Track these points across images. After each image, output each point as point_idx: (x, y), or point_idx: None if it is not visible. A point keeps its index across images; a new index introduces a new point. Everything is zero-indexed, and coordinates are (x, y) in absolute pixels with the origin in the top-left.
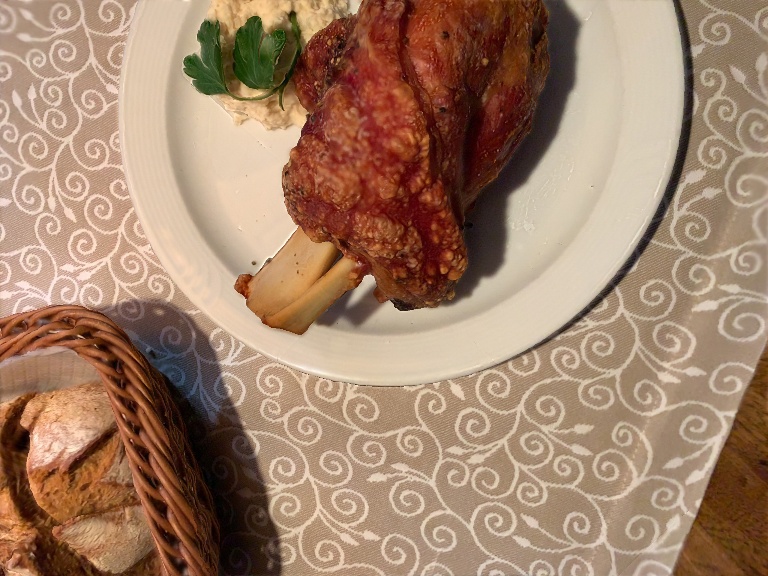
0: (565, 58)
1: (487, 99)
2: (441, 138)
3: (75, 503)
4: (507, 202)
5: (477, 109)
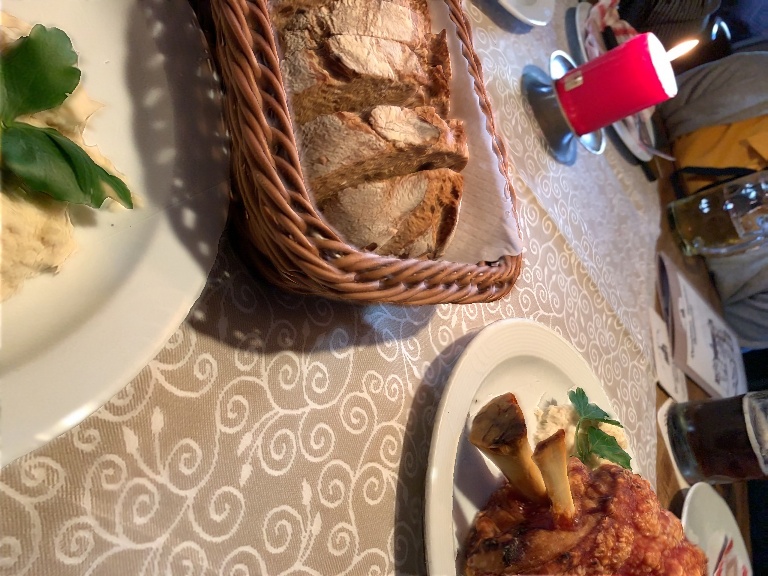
0: None
1: None
2: None
3: (428, 196)
4: None
5: None
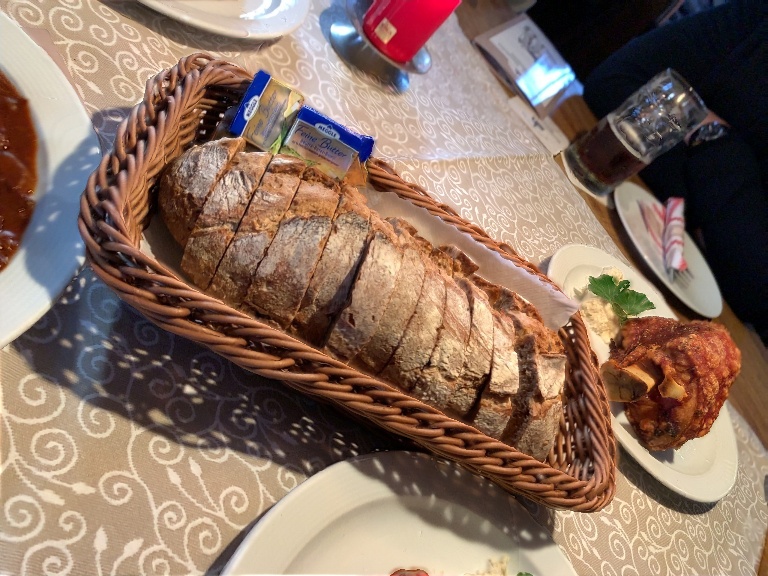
0: None
1: None
2: None
3: None
4: None
5: None
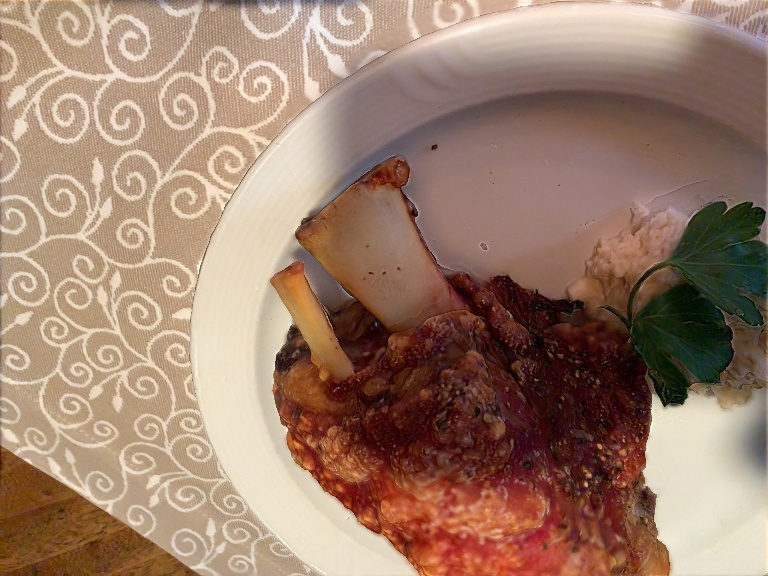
0: None
1: None
2: None
3: None
4: None
5: None
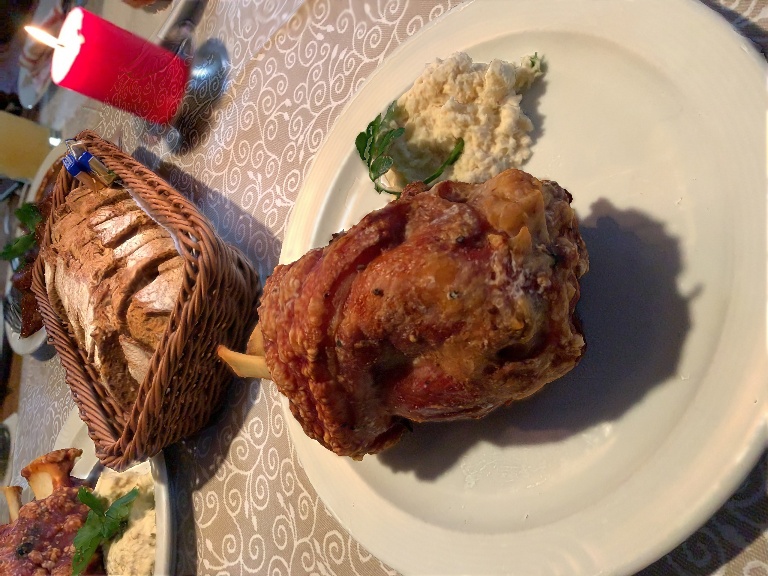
0: (632, 389)
1: (419, 364)
2: (337, 359)
3: (140, 333)
4: (477, 443)
5: (407, 363)
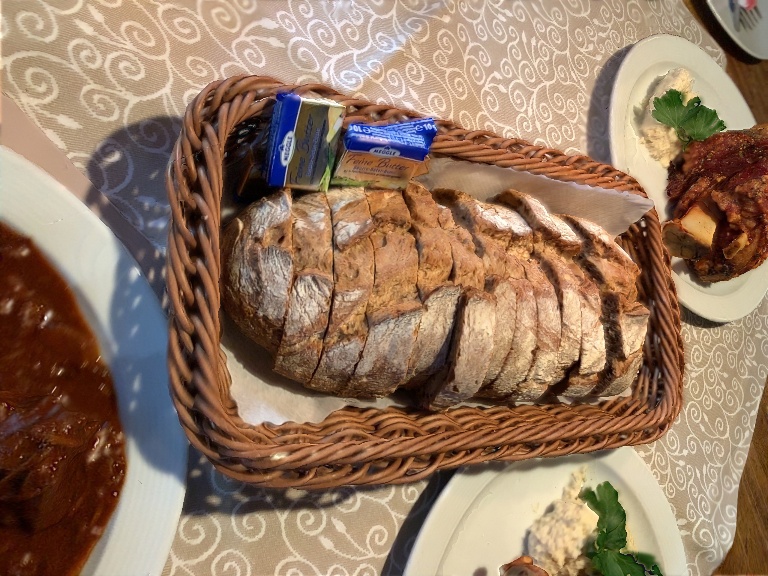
0: None
1: None
2: None
3: None
4: None
5: None
